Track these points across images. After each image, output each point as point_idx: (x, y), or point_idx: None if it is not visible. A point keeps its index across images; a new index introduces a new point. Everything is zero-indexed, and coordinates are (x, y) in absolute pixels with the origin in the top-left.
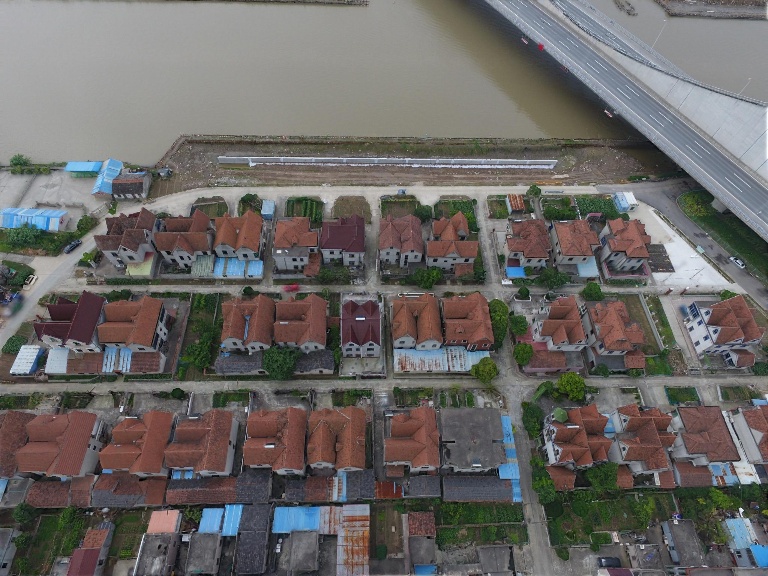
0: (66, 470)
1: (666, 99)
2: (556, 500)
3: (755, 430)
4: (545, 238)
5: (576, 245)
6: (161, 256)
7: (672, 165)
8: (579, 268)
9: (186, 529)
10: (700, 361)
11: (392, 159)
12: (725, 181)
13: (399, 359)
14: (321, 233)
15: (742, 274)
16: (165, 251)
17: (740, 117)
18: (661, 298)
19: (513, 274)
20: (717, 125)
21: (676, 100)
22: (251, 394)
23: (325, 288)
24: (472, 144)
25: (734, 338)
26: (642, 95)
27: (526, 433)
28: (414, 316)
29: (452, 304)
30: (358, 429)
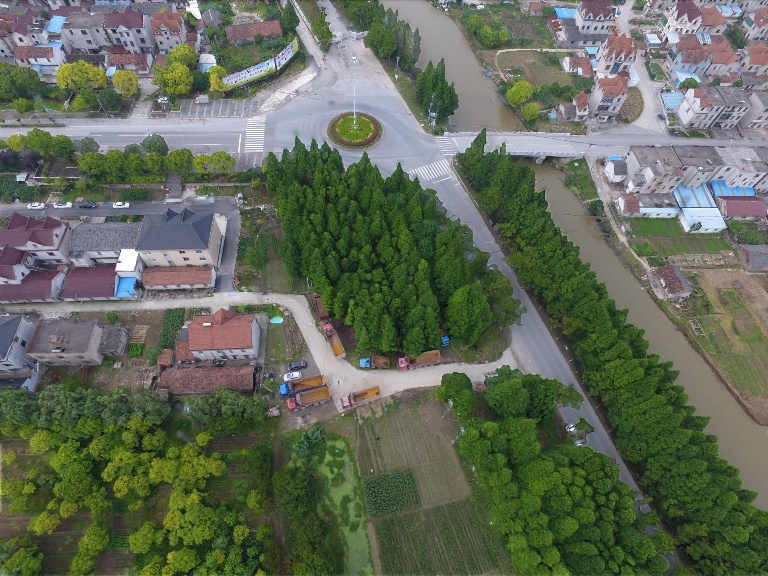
0: None
1: None
2: None
3: None
4: None
5: None
6: None
7: None
8: None
9: None
10: None
11: None
12: None
13: None
14: None
15: None
16: None
17: None
18: None
19: None
20: None
21: None
22: None
23: None
24: None
25: None
26: None
27: None
28: None
29: None
30: None
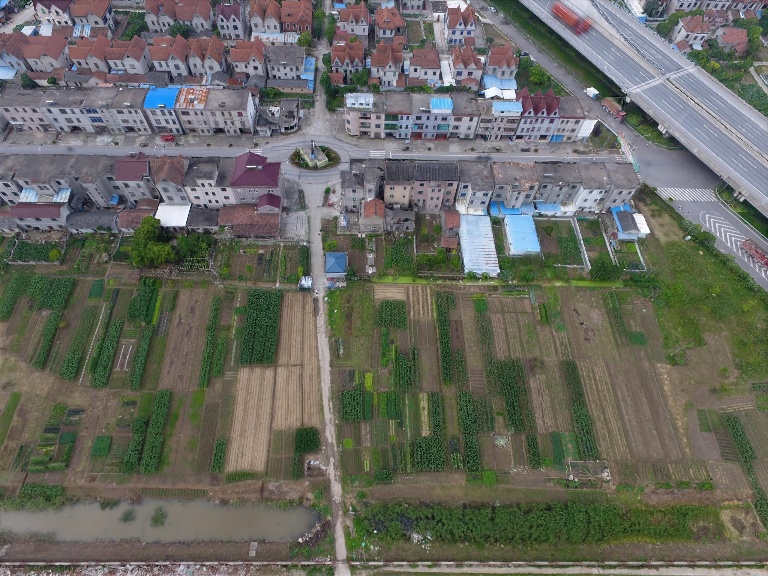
0: (50, 54)
1: None
2: None
3: None
4: None
5: None
6: None
7: None
8: (382, 5)
9: None
10: None
11: None
12: None
13: (254, 36)
14: None
15: (493, 15)
16: None
17: None
18: (434, 23)
19: (338, 6)
20: None
21: None
22: None
23: None
24: None
25: (458, 22)
26: None
27: None
28: (263, 9)
29: (286, 3)
30: (217, 47)
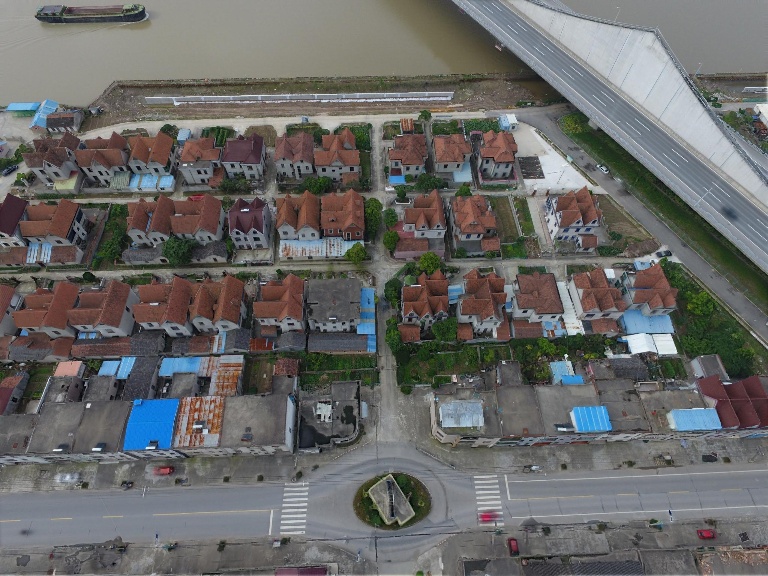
0: None
1: (549, 32)
2: (404, 350)
3: (579, 289)
4: (421, 148)
5: (449, 153)
6: (86, 176)
7: (560, 94)
8: (455, 175)
9: (88, 377)
10: (554, 247)
11: (302, 95)
12: (592, 98)
13: (284, 248)
14: (223, 150)
15: (606, 178)
16: (86, 168)
17: (603, 39)
18: (528, 199)
19: (395, 181)
20: (588, 50)
21: (556, 31)
22: (153, 278)
23: None
24: (377, 81)
25: (575, 220)
26: (529, 30)
27: (390, 304)
28: (295, 210)
29: (328, 199)
30: (234, 293)
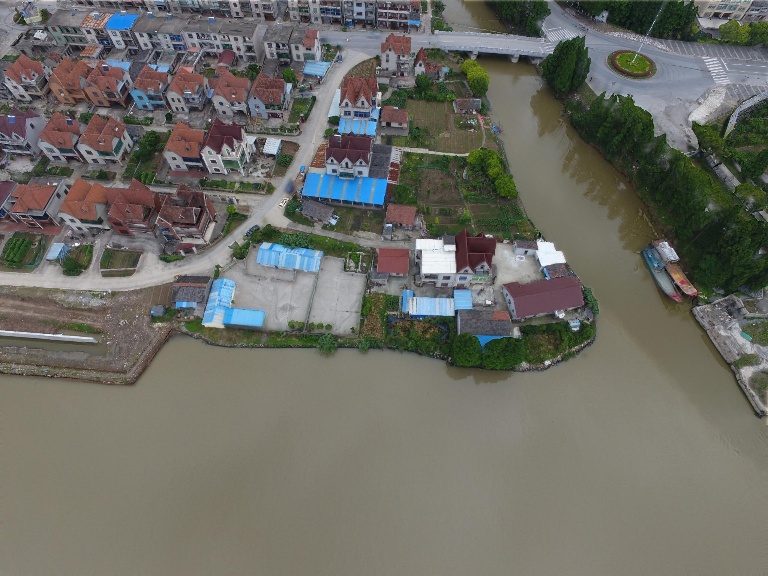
0: None
1: None
2: None
3: None
4: None
5: None
6: None
7: None
8: None
9: None
10: None
11: None
12: None
13: None
14: (8, 196)
15: None
16: None
17: None
18: None
19: None
20: None
21: None
22: None
23: (38, 169)
24: None
25: None
26: None
27: None
28: None
29: None
30: None
